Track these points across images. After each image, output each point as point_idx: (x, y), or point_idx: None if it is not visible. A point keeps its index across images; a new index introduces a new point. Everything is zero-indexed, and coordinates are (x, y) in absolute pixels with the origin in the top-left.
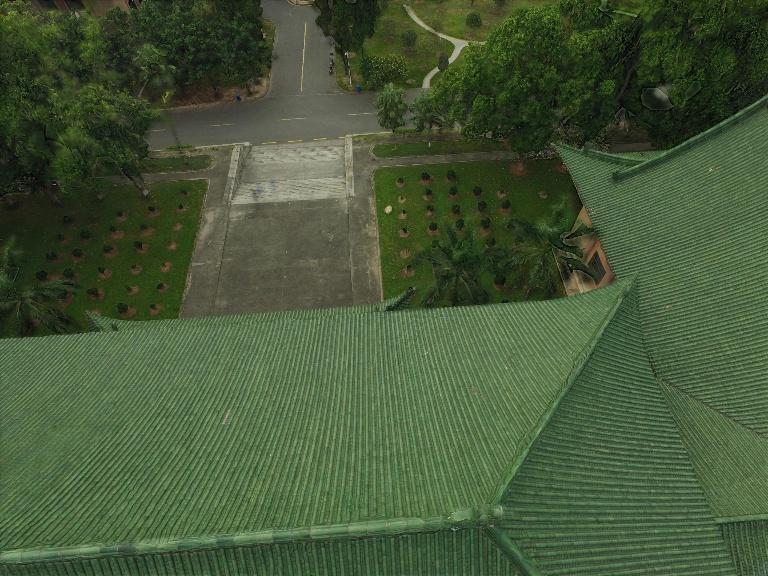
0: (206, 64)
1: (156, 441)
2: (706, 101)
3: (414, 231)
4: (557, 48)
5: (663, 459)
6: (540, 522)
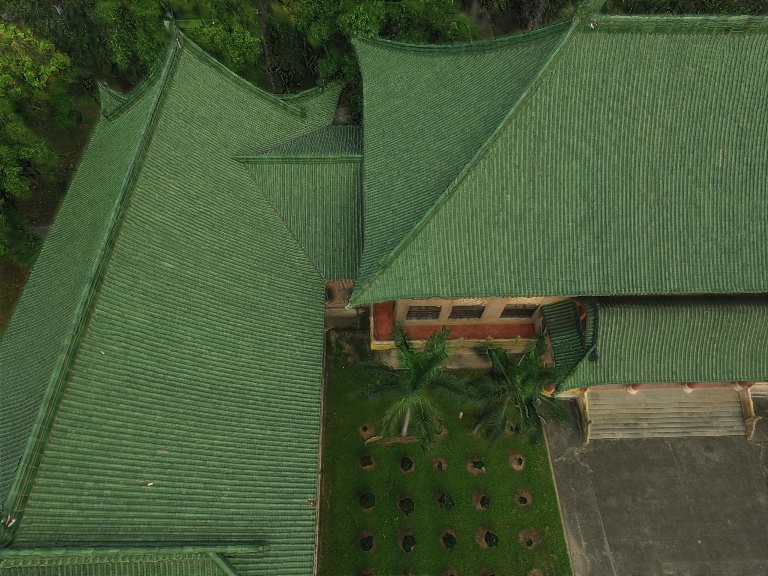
0: None
1: (762, 137)
2: None
3: None
4: None
5: None
6: None
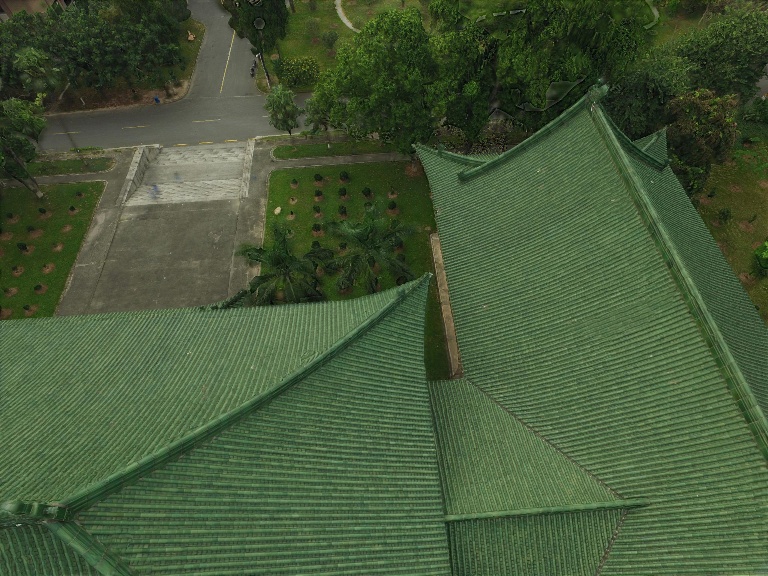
0: (115, 66)
1: None
2: None
3: (299, 232)
4: (418, 50)
5: (401, 457)
6: (171, 518)
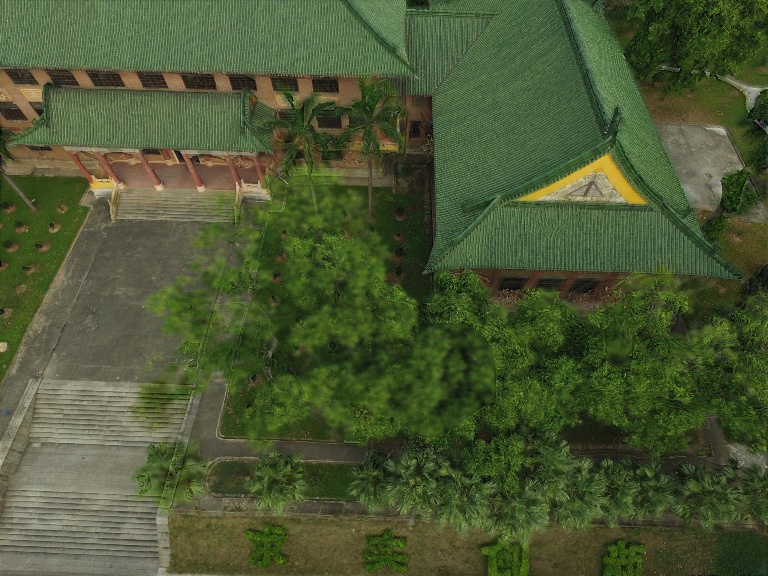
0: None
1: None
2: None
3: None
4: None
5: None
6: None
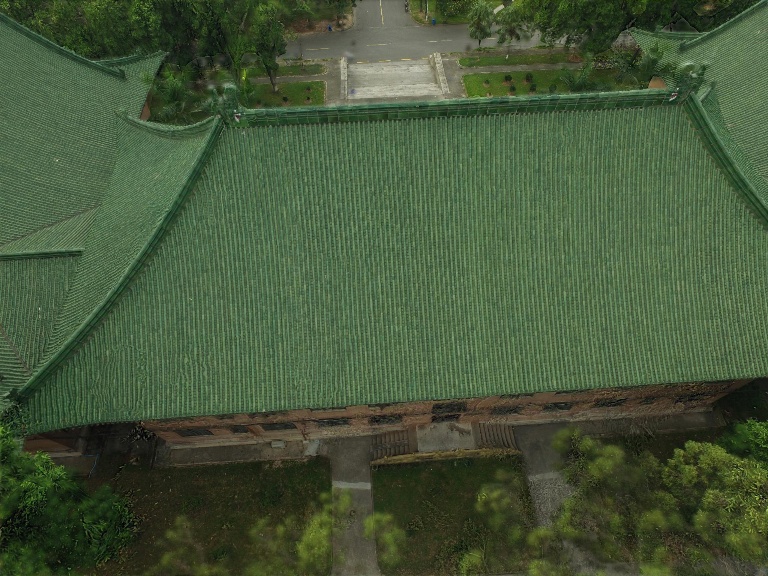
0: None
1: None
2: (744, 7)
3: None
4: None
5: None
6: None
